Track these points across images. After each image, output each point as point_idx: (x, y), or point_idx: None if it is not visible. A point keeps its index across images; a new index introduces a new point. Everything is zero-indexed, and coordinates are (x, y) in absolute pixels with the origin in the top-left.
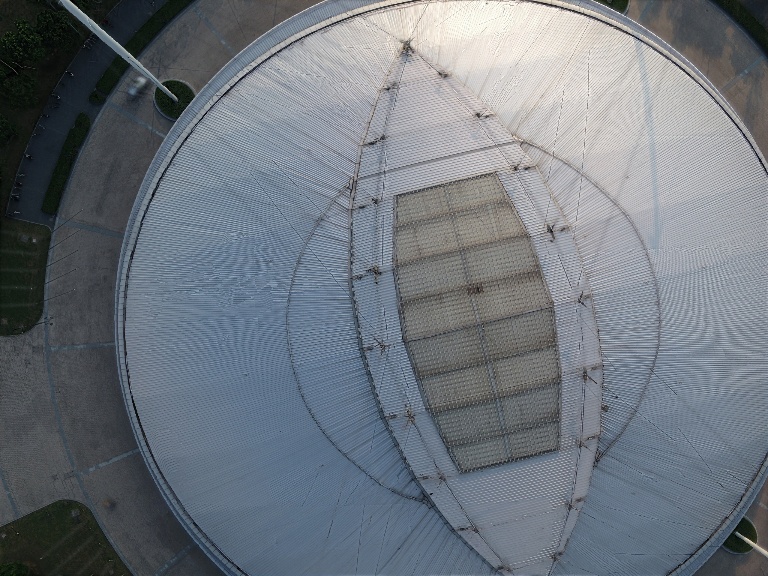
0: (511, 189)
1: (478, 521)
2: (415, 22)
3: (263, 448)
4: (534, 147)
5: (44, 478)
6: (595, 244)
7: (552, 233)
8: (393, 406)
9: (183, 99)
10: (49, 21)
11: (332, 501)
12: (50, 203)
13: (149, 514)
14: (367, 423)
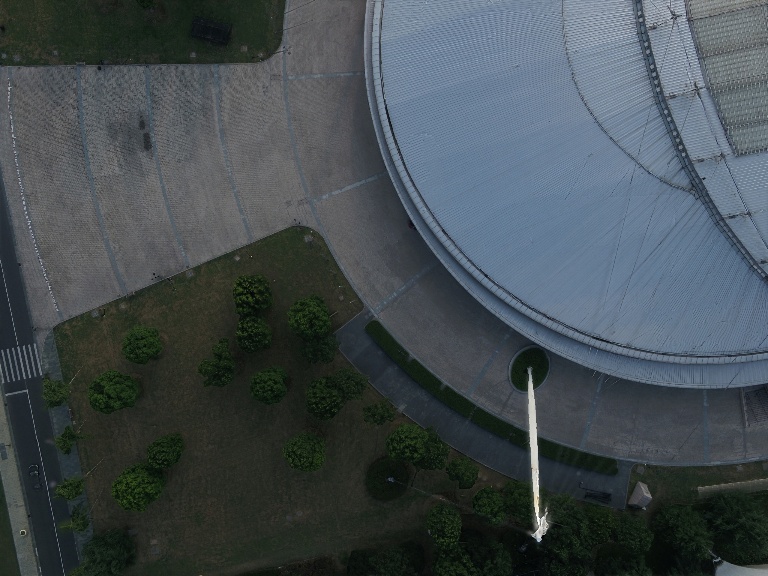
0: None
1: (748, 208)
2: None
3: (529, 140)
4: None
5: (278, 204)
6: None
7: None
8: (674, 86)
9: None
10: None
11: (597, 193)
12: None
13: (379, 243)
14: (641, 109)
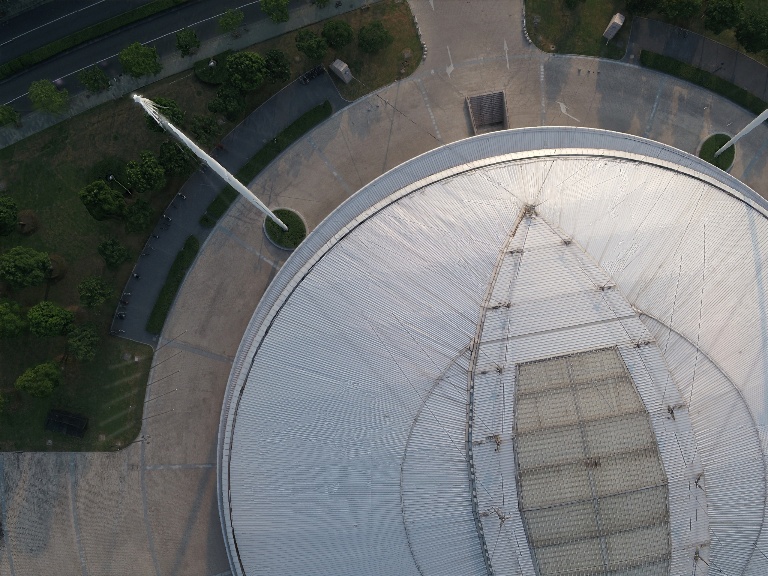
0: (631, 364)
1: None
2: (536, 180)
3: None
4: (652, 319)
5: None
6: (708, 420)
7: (672, 414)
8: (505, 573)
9: (293, 228)
10: (173, 153)
11: None
12: (155, 323)
13: None
14: None
